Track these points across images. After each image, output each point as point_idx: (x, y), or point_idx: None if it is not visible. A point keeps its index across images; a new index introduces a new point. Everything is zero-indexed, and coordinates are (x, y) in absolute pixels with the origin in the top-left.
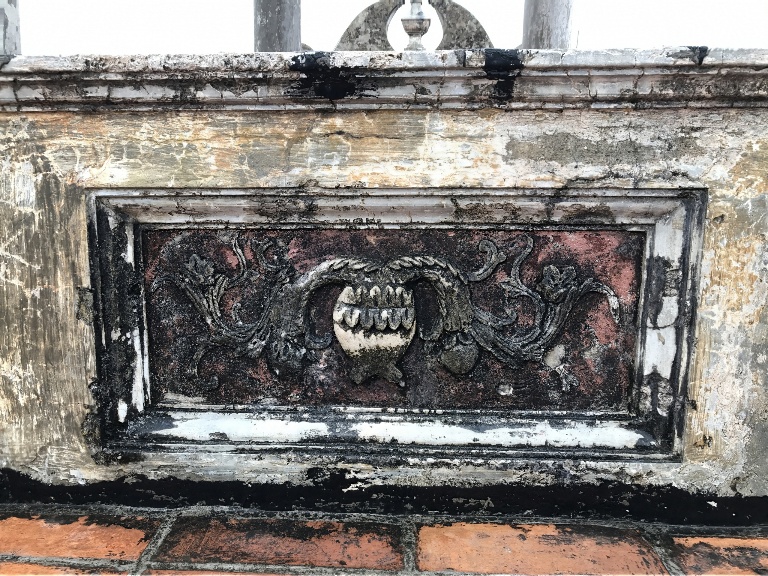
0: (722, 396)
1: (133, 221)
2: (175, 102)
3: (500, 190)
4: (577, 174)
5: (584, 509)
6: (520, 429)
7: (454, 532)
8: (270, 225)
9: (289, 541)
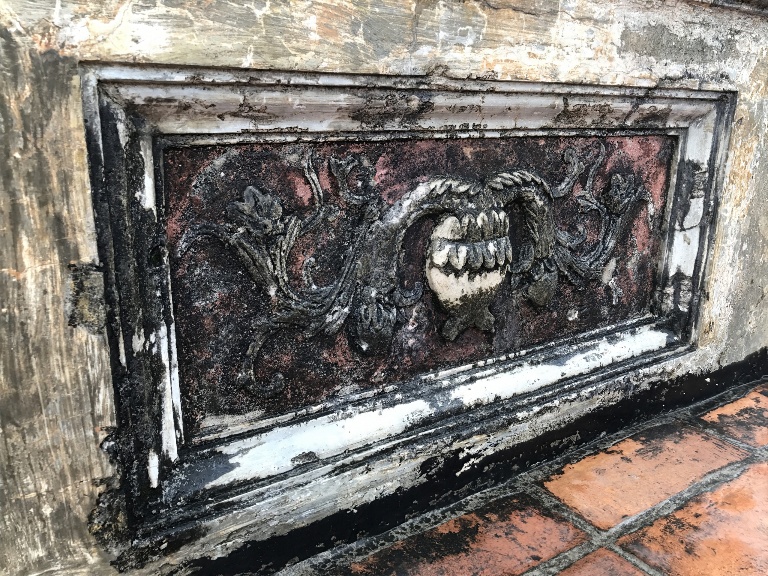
0: (722, 284)
1: (151, 131)
2: None
3: (608, 88)
4: (666, 72)
5: (638, 415)
6: (589, 352)
7: (576, 478)
8: (358, 135)
9: (454, 560)
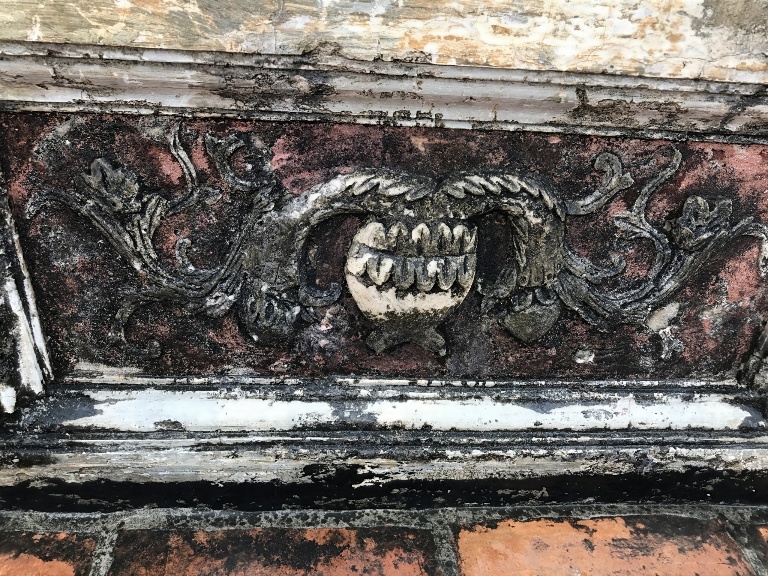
0: None
1: None
2: None
3: (668, 81)
4: None
5: (658, 495)
6: (596, 407)
7: (503, 541)
8: (239, 112)
9: (287, 574)
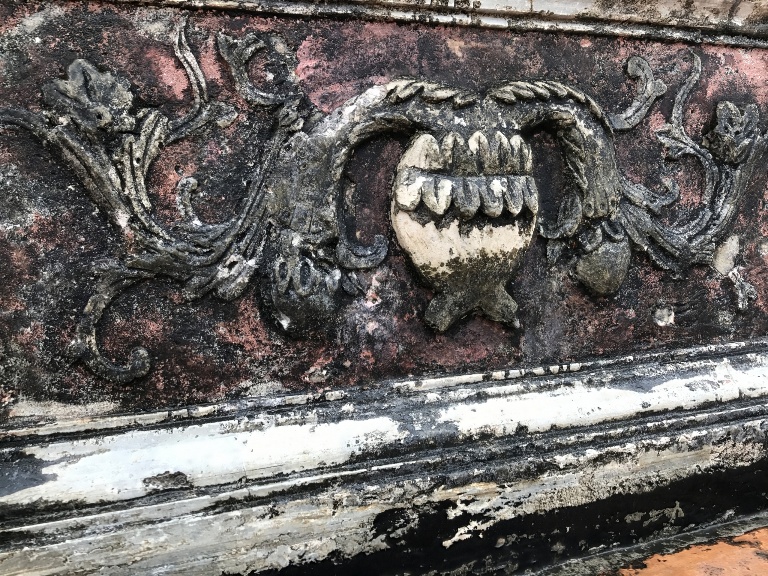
0: None
1: None
2: None
3: None
4: None
5: None
6: (697, 378)
7: None
8: (260, 1)
9: None
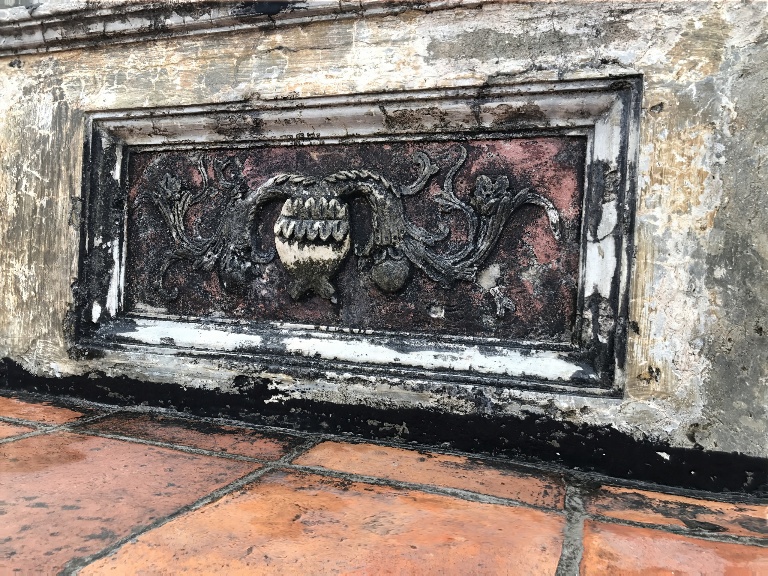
0: (671, 318)
1: (123, 143)
2: (151, 32)
3: (423, 93)
4: (498, 70)
5: (507, 446)
6: (446, 353)
7: (354, 447)
8: (229, 144)
9: (193, 432)
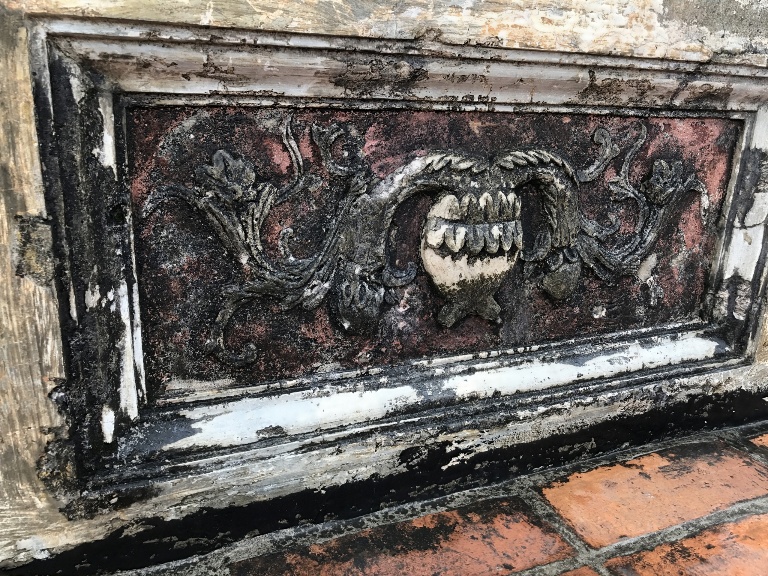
0: None
1: (111, 88)
2: None
3: (646, 61)
4: (723, 45)
5: (672, 429)
6: (616, 355)
7: (581, 488)
8: (343, 102)
9: (419, 556)
